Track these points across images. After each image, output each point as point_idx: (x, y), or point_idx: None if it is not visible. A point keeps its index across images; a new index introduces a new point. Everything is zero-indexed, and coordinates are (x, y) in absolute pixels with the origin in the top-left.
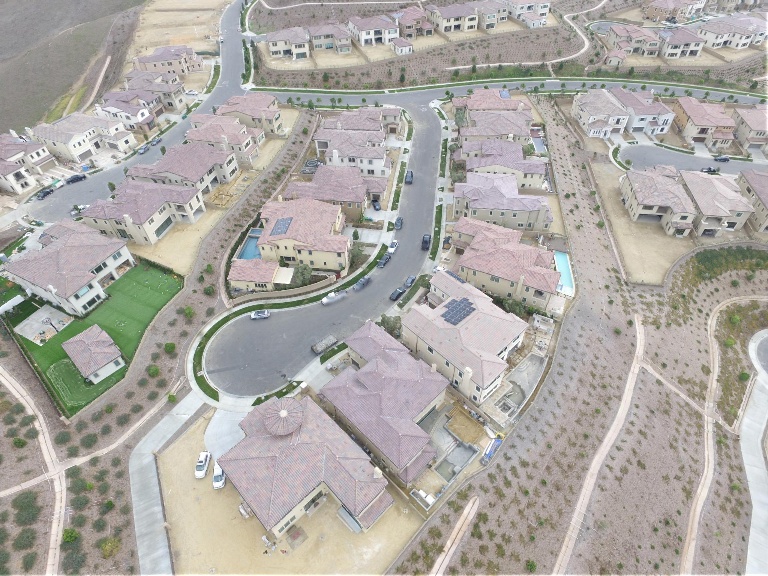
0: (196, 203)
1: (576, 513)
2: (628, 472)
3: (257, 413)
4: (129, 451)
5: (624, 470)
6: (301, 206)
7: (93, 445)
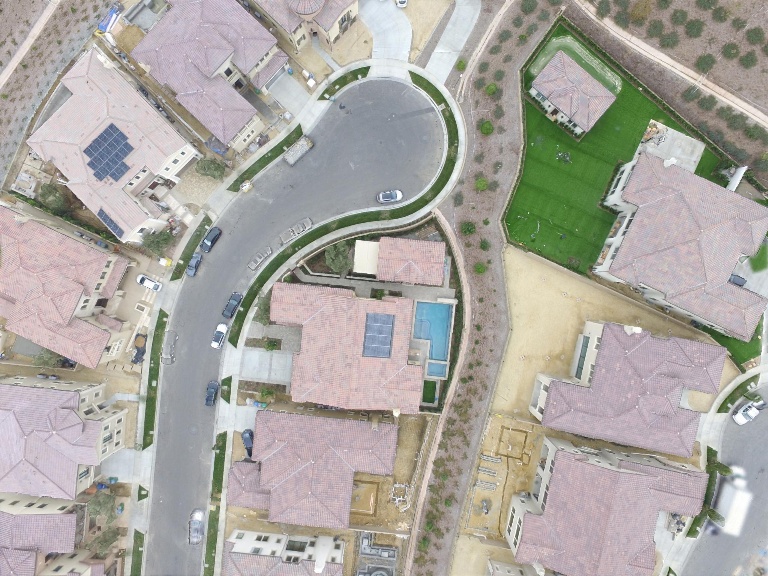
0: (542, 403)
1: (58, 3)
2: (0, 44)
3: (339, 3)
4: (485, 6)
5: (3, 44)
6: (354, 384)
7: (523, 2)
